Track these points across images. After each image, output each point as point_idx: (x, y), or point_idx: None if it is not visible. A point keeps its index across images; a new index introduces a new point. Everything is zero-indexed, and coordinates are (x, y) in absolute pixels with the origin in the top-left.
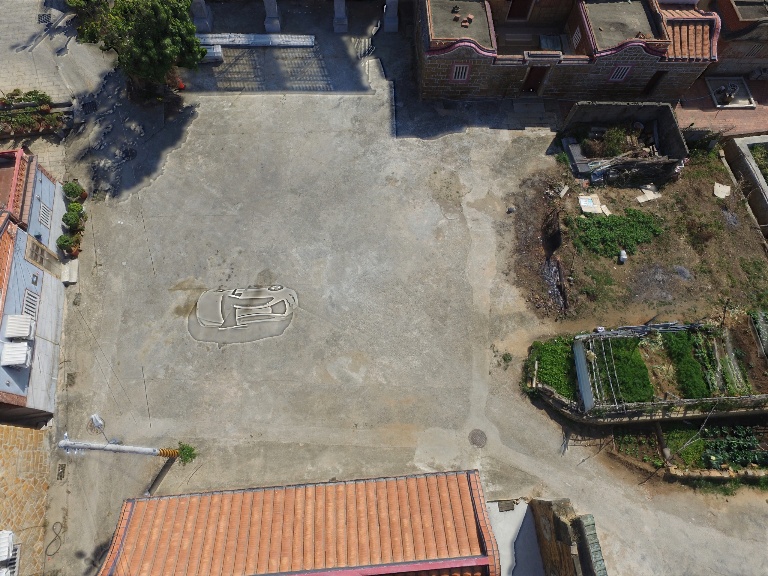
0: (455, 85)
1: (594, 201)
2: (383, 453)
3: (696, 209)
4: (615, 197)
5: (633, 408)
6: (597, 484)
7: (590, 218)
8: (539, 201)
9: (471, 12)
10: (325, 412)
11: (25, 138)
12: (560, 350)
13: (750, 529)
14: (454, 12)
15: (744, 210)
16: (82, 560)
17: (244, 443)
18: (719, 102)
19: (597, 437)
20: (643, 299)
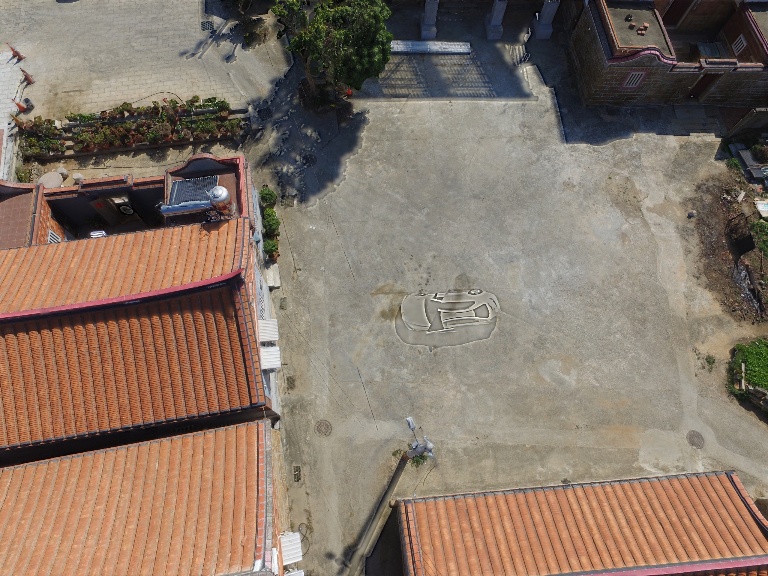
0: (623, 92)
1: None
2: (609, 454)
3: None
4: None
5: None
6: None
7: None
8: (717, 206)
9: (643, 20)
10: (545, 414)
11: (203, 144)
12: (765, 352)
13: None
14: (628, 20)
15: None
16: (333, 560)
17: (472, 445)
18: None
19: None
20: None
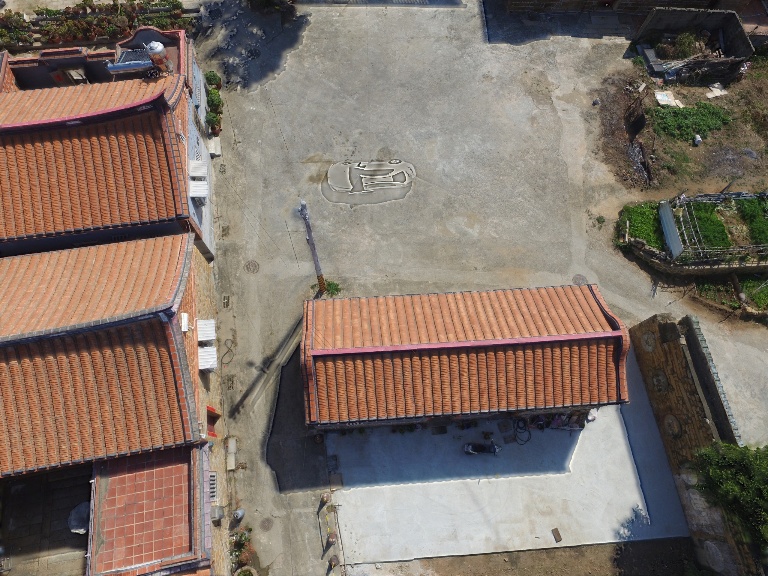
0: None
1: (669, 96)
2: None
3: (759, 104)
4: (687, 93)
5: (714, 257)
6: None
7: (666, 109)
8: (620, 95)
9: None
10: (448, 258)
11: None
12: (648, 212)
13: None
14: None
15: None
16: (253, 368)
17: (381, 281)
18: None
19: (681, 285)
20: (717, 174)
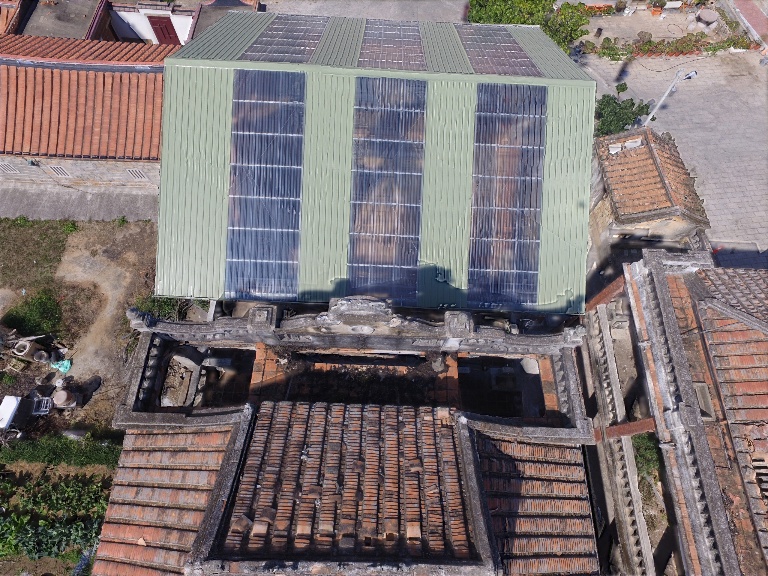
0: None
1: None
2: None
3: None
4: None
5: None
6: None
7: None
8: None
9: None
10: None
11: None
12: None
13: None
14: None
15: None
16: None
17: None
18: None
19: None
20: None
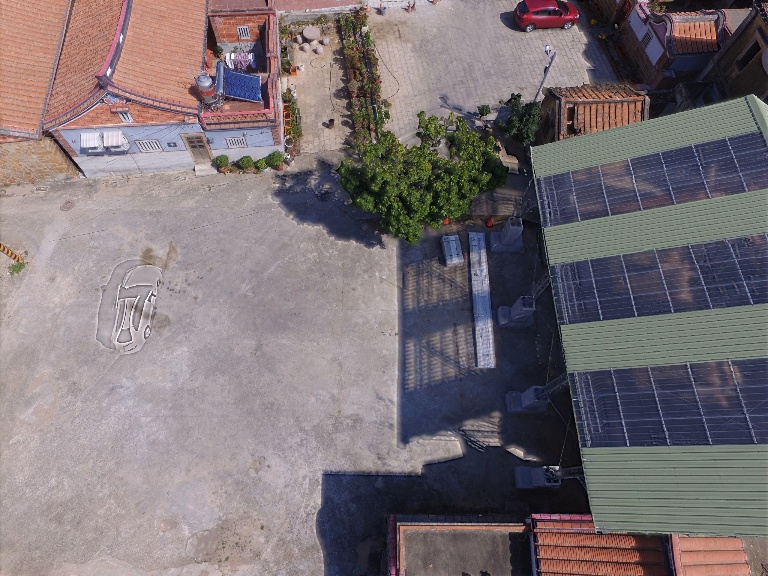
0: None
1: None
2: None
3: None
4: None
5: None
6: None
7: None
8: None
9: None
10: (4, 381)
11: (352, 121)
12: None
13: None
14: None
15: None
16: None
17: (6, 311)
18: None
19: None
20: None
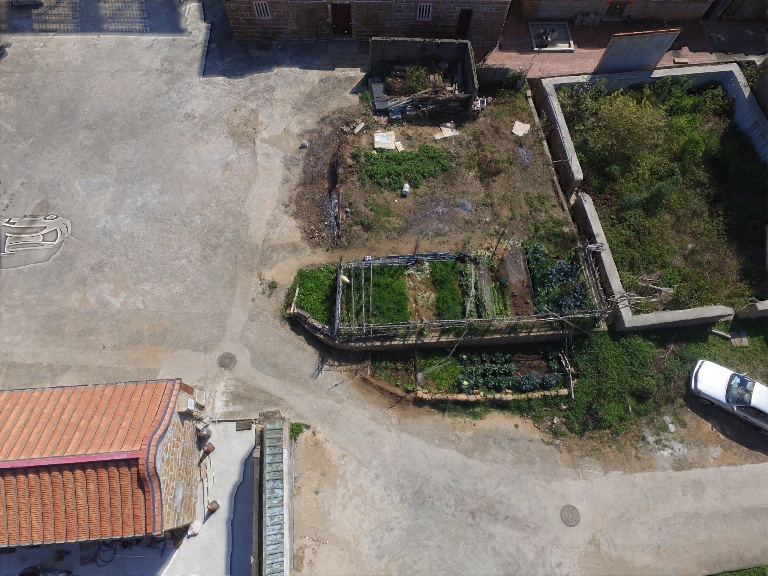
0: (263, 24)
1: (389, 138)
2: (126, 373)
3: (491, 146)
4: (412, 134)
5: (384, 332)
6: (345, 407)
7: (380, 153)
8: (333, 137)
9: None
10: (75, 334)
11: None
12: (322, 277)
13: (492, 452)
14: None
15: (540, 147)
16: None
17: None
18: (538, 45)
19: (354, 363)
20: (419, 230)
